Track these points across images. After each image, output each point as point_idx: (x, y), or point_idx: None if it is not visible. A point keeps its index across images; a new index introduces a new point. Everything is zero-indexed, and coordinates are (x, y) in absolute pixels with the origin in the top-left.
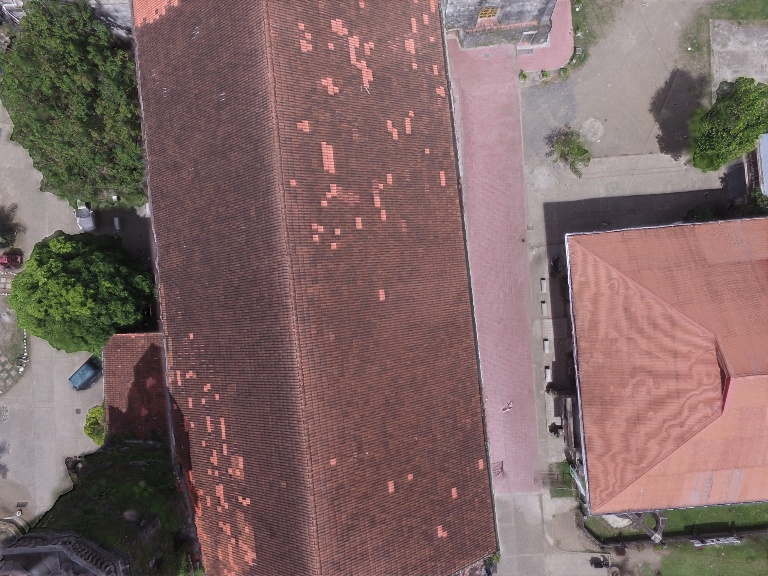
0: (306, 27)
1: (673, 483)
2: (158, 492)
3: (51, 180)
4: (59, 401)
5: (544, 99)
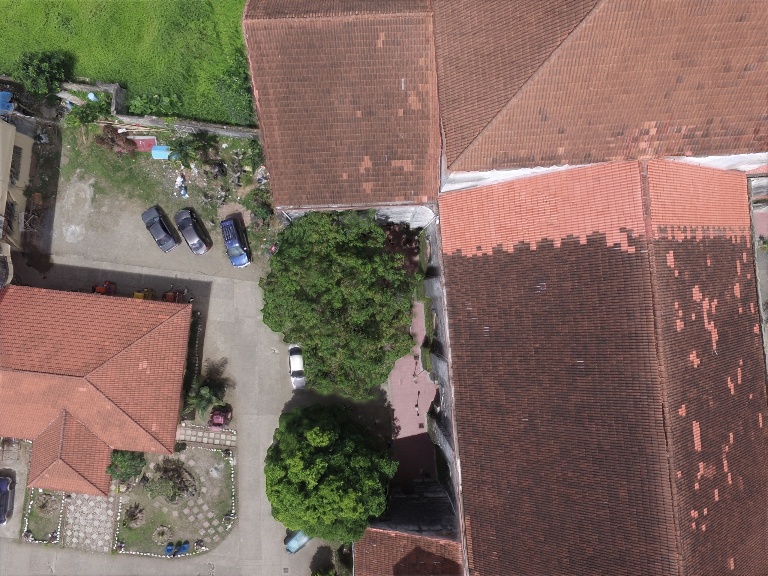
0: (679, 304)
1: None
2: None
3: (323, 382)
4: (267, 560)
5: (762, 265)
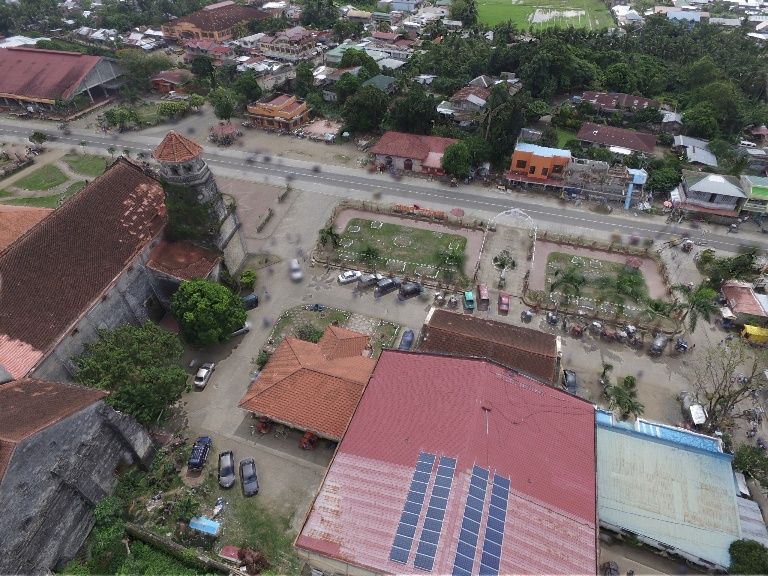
0: None
1: (21, 209)
2: None
3: (162, 330)
4: (274, 298)
5: None
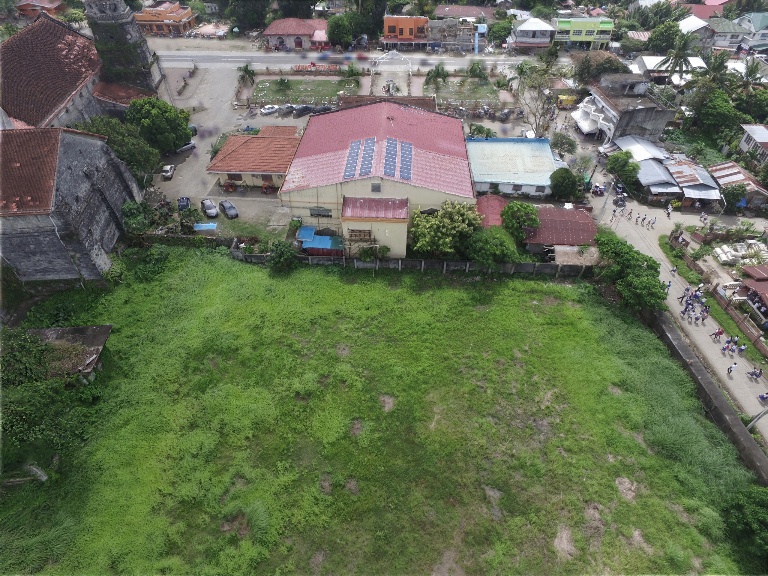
0: None
1: None
2: (98, 49)
3: None
4: None
5: None
